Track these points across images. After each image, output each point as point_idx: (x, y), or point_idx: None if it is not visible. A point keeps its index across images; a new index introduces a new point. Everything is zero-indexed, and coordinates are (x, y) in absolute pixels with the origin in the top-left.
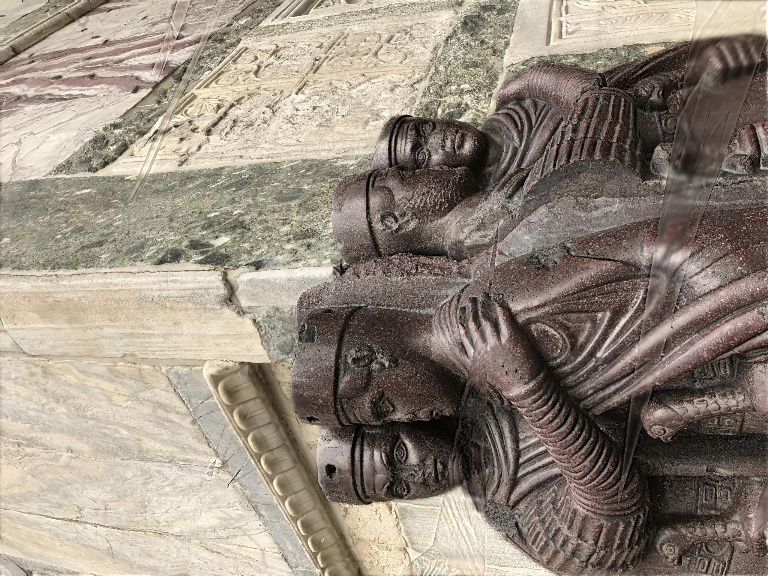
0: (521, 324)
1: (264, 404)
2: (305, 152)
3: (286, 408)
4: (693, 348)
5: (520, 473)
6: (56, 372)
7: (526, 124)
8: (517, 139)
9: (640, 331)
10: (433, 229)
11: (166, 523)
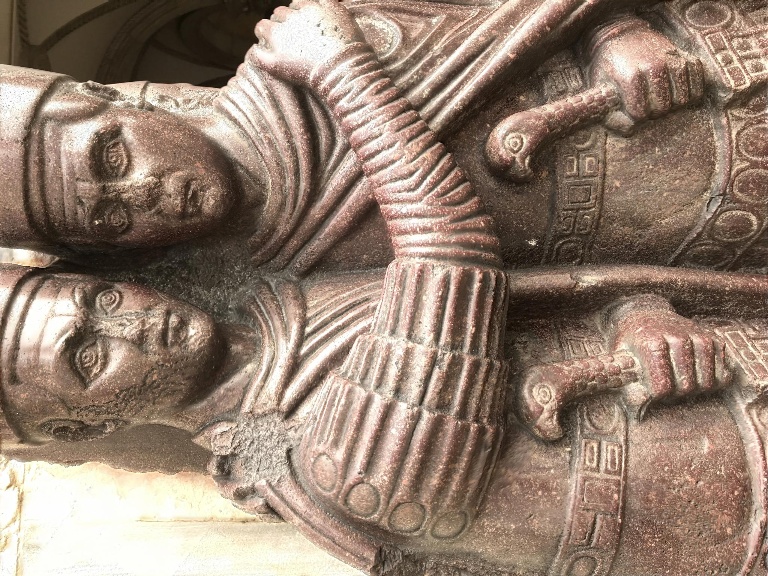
0: None
1: None
2: None
3: None
4: (545, 2)
5: (305, 348)
6: None
7: None
8: None
9: None
10: None
11: None
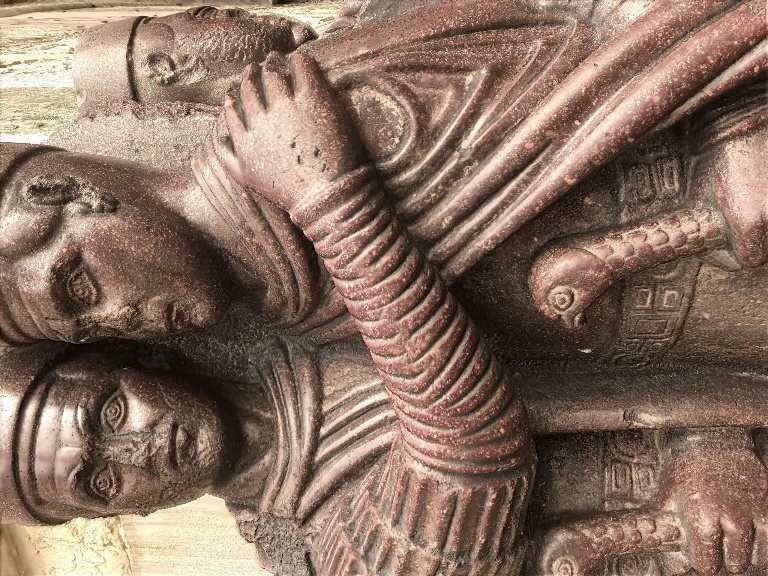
0: (334, 84)
1: None
2: None
3: None
4: (634, 91)
5: (320, 454)
6: None
7: None
8: None
9: (537, 97)
10: None
11: None
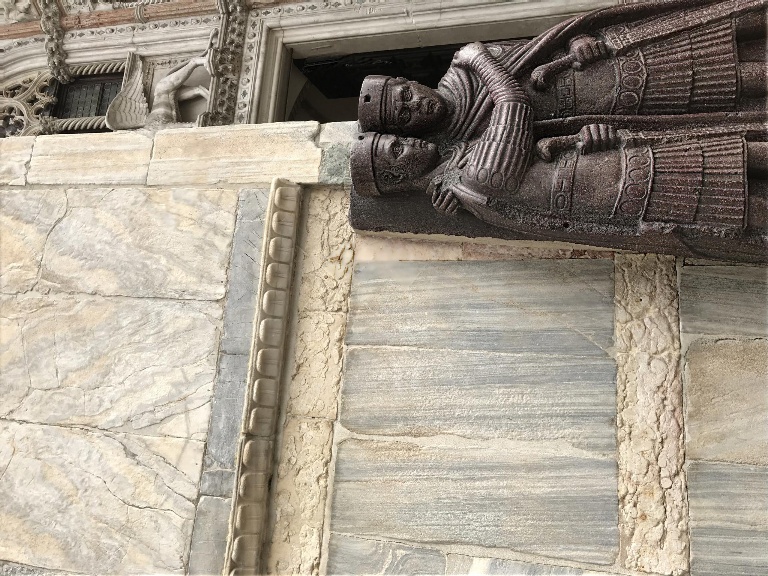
0: None
1: (295, 220)
2: None
3: (302, 240)
4: (549, 32)
5: None
6: (155, 201)
7: None
8: None
9: None
10: None
11: (109, 404)
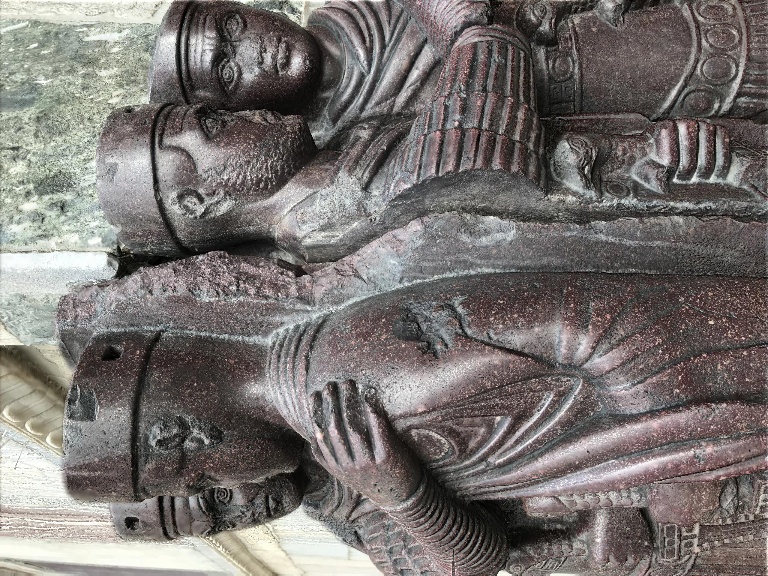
0: (400, 432)
1: (20, 378)
2: (33, 4)
3: (53, 370)
4: (609, 477)
5: (364, 496)
6: None
7: (377, 39)
8: (364, 62)
9: (545, 440)
10: (255, 213)
11: None
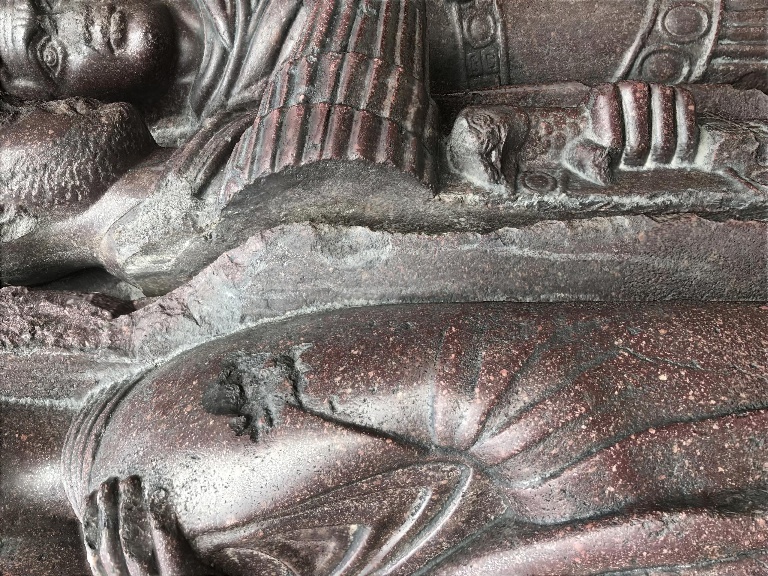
0: (205, 553)
1: None
2: None
3: None
4: None
5: None
6: None
7: (239, 4)
8: (225, 34)
9: (425, 558)
10: (68, 233)
11: None
